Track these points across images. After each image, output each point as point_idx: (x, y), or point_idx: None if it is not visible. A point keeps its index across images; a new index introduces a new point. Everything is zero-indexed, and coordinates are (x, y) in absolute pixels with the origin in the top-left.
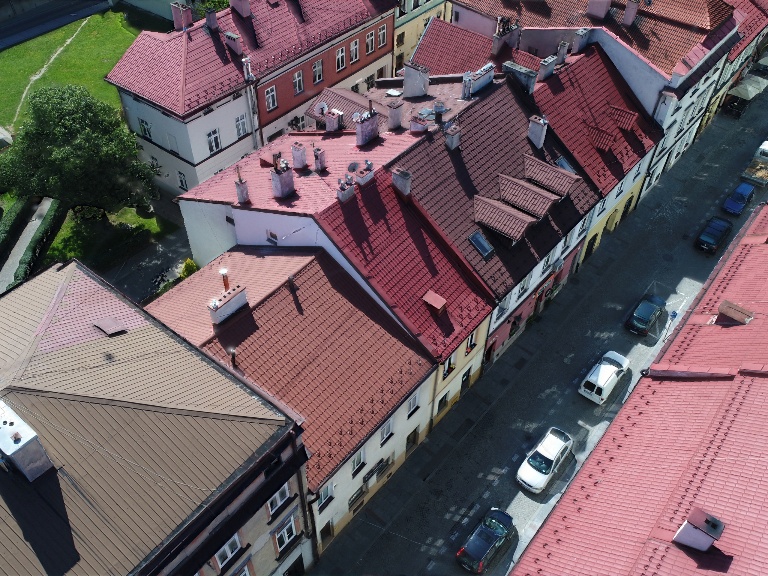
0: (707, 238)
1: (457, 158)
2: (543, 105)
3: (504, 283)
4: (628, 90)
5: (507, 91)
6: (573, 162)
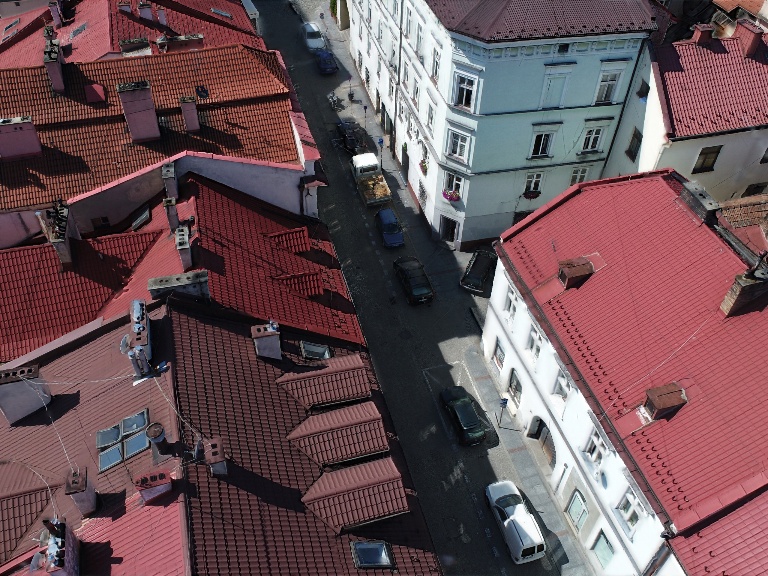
0: (419, 290)
1: (239, 476)
2: (229, 299)
3: (431, 569)
4: (260, 203)
5: (182, 319)
6: (314, 338)
